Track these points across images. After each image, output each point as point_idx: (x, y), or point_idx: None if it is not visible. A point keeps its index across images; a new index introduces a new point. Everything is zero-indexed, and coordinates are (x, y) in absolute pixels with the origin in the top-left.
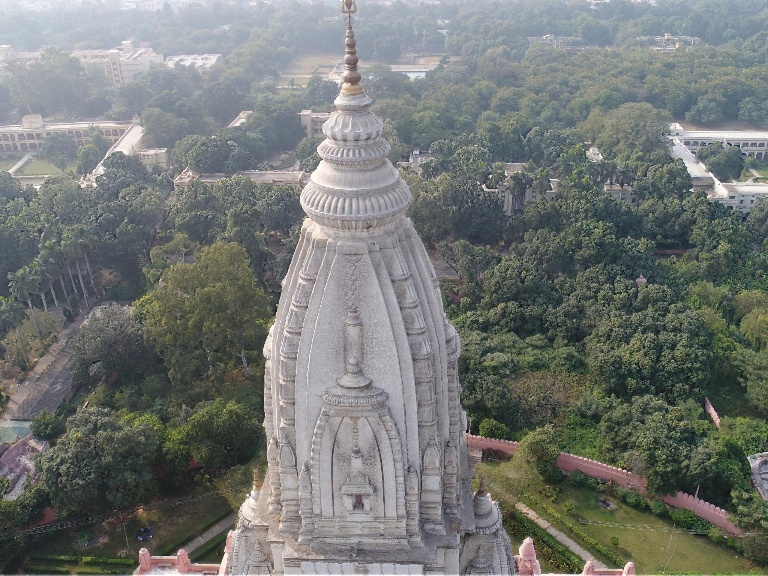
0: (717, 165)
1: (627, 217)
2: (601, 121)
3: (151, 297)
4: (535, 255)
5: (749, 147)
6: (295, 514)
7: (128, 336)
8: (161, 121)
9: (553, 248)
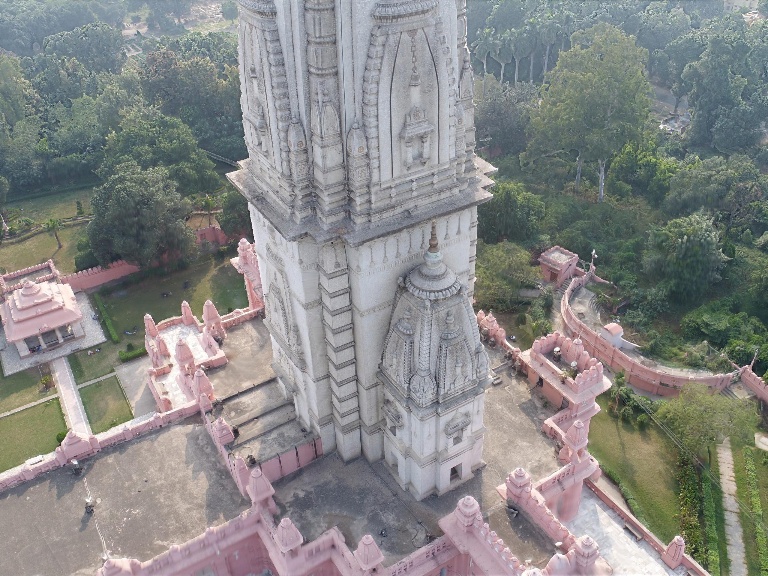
0: None
1: None
2: None
3: None
4: None
5: None
6: None
7: (517, 111)
8: None
9: None
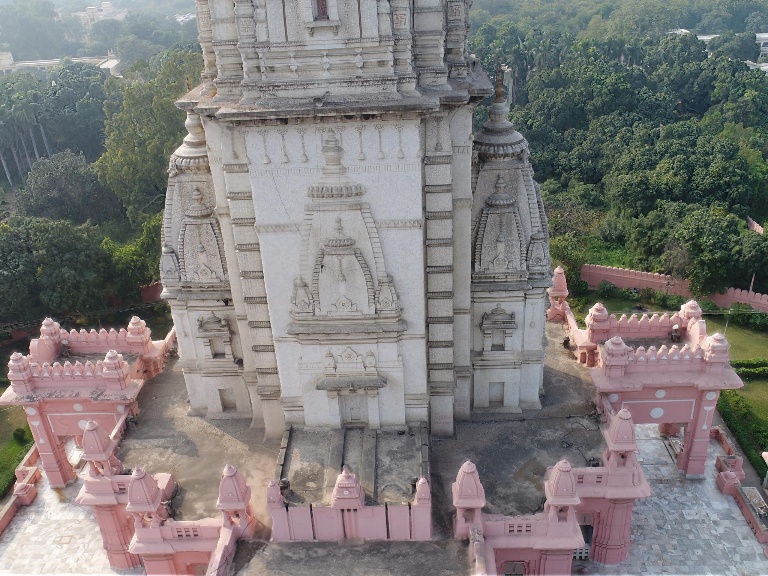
0: (731, 51)
1: (640, 81)
2: (603, 26)
3: (106, 132)
4: (541, 110)
5: (761, 48)
6: (235, 72)
7: (81, 179)
8: (136, 47)
9: (561, 99)
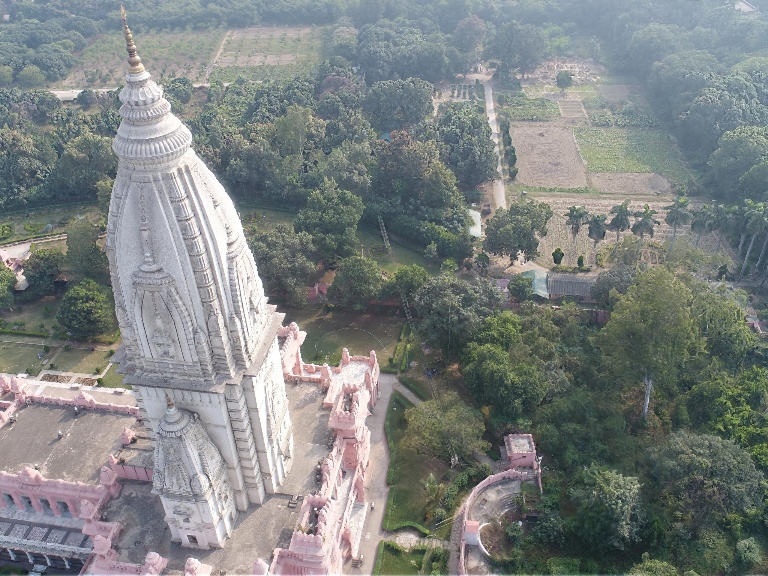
0: None
1: None
2: None
3: None
4: None
5: None
6: None
7: None
8: None
9: None
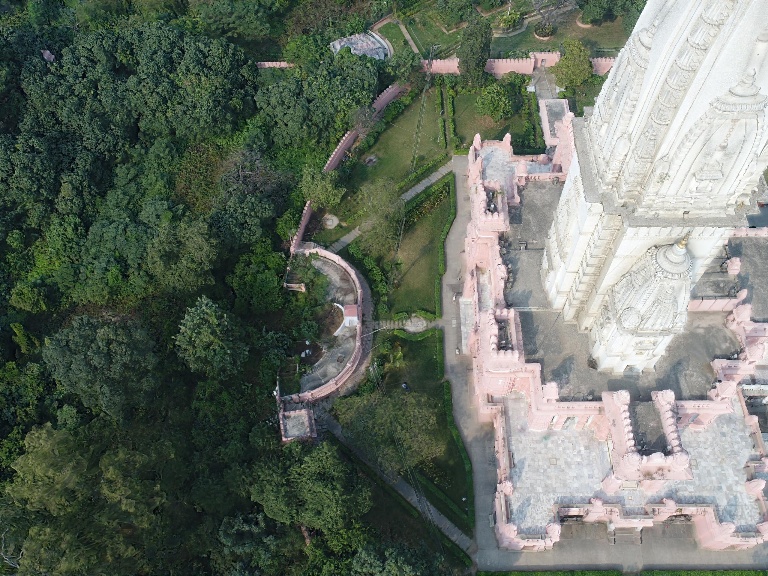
0: None
1: None
2: None
3: None
4: None
5: None
6: None
7: None
8: None
9: None
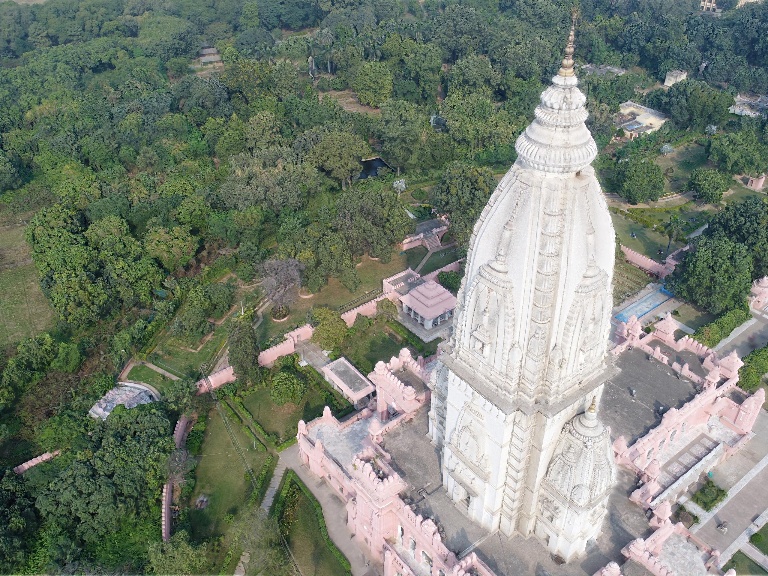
0: None
1: None
2: None
3: None
4: None
5: None
6: None
7: None
8: None
9: None
